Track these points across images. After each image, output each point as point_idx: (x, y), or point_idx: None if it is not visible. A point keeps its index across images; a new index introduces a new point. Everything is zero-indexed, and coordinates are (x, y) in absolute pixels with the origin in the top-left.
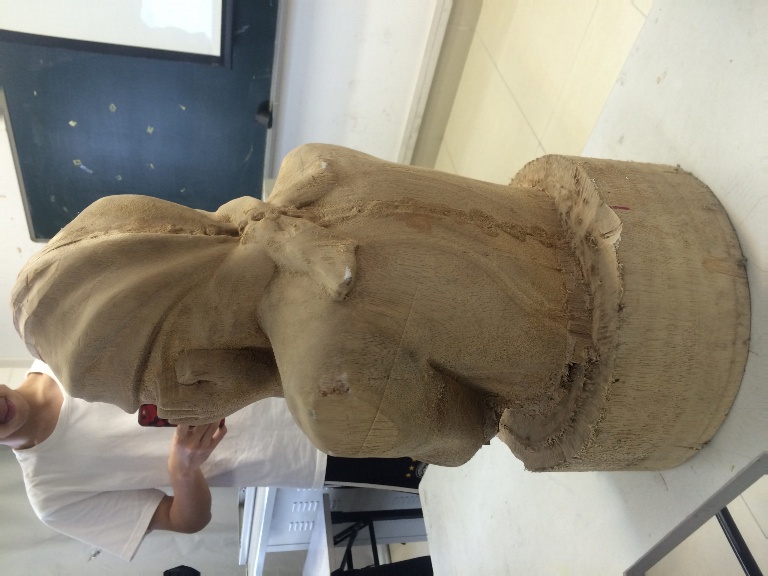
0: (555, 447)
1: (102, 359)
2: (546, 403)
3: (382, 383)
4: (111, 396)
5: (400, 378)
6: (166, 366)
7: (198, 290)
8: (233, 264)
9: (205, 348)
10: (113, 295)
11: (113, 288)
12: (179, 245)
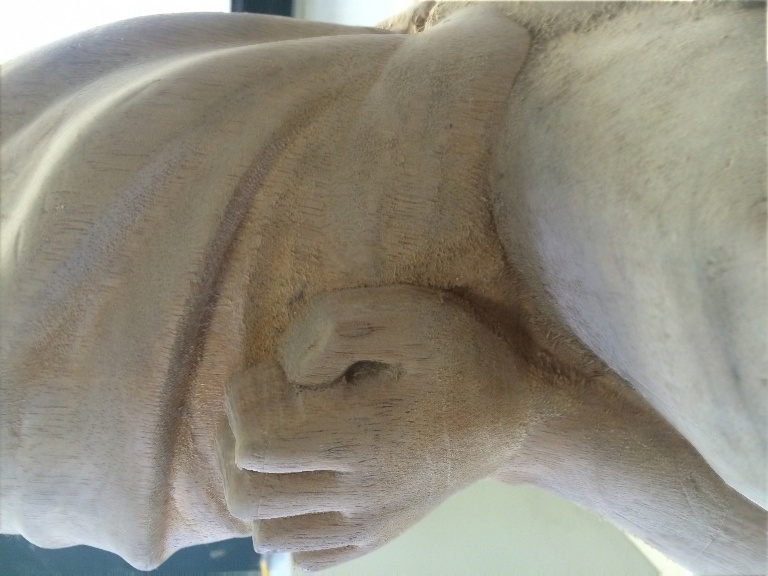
0: None
1: (78, 323)
2: None
3: None
4: (92, 478)
5: None
6: (254, 350)
7: (343, 109)
8: (426, 41)
9: (360, 283)
10: (127, 92)
11: (127, 84)
12: (289, 29)
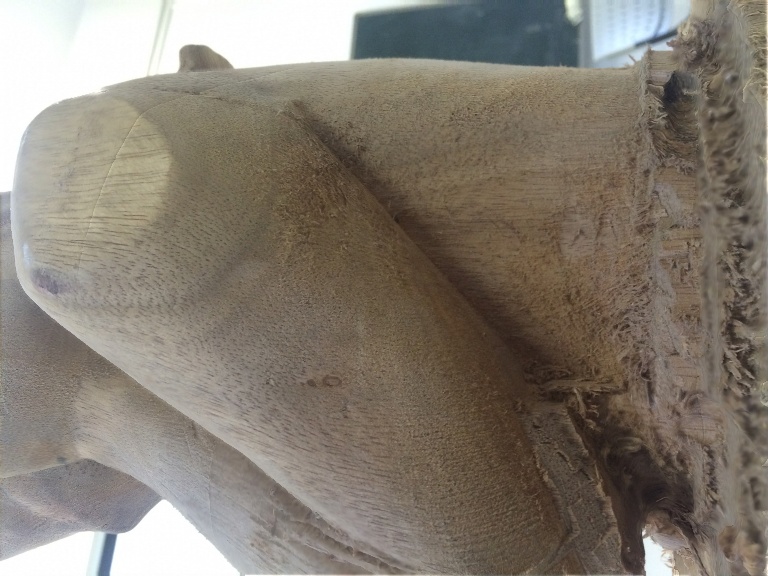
0: (763, 378)
1: None
2: (661, 245)
3: (176, 94)
4: None
5: (218, 96)
6: None
7: None
8: None
9: None
10: None
11: None
12: None
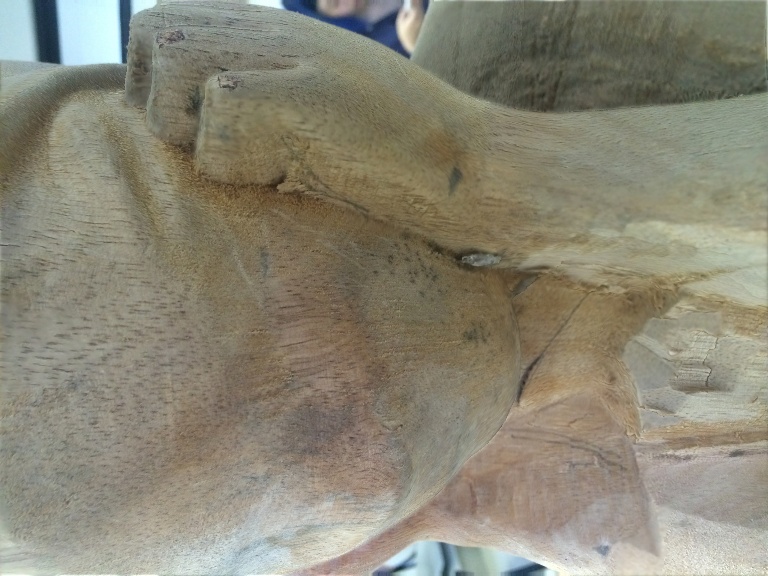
0: None
1: None
2: None
3: None
4: None
5: None
6: None
7: None
8: None
9: None
10: None
11: None
12: None
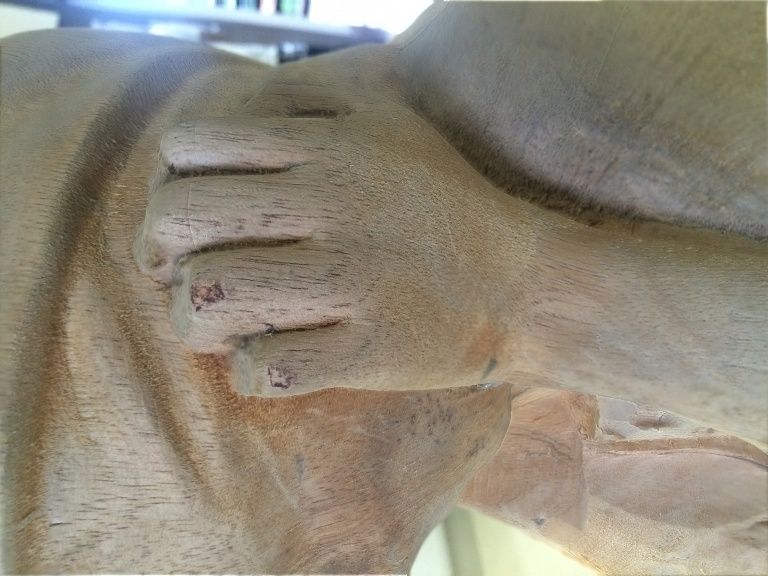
0: None
1: None
2: None
3: None
4: None
5: None
6: None
7: None
8: None
9: None
10: None
11: None
12: None
